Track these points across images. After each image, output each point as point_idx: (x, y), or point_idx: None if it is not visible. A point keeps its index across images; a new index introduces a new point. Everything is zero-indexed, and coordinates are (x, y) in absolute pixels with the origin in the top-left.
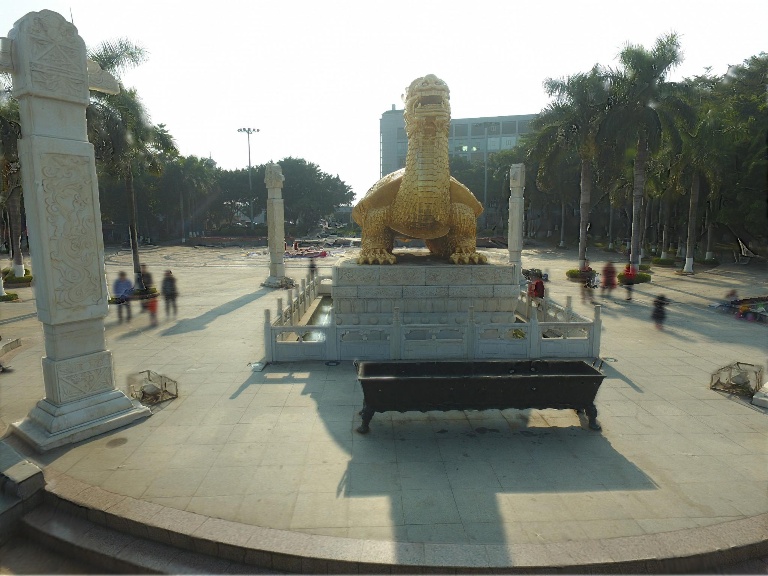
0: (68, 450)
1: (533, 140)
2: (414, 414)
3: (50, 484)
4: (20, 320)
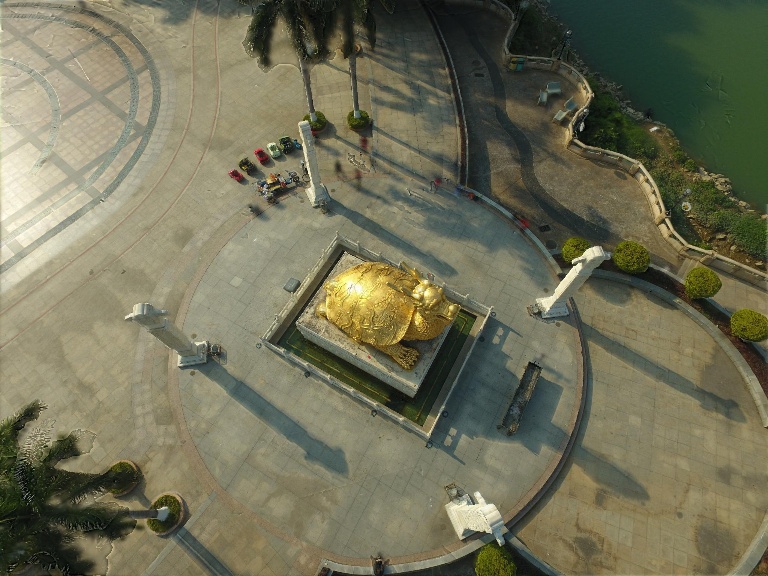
0: None
1: (250, 33)
2: None
3: None
4: (231, 573)
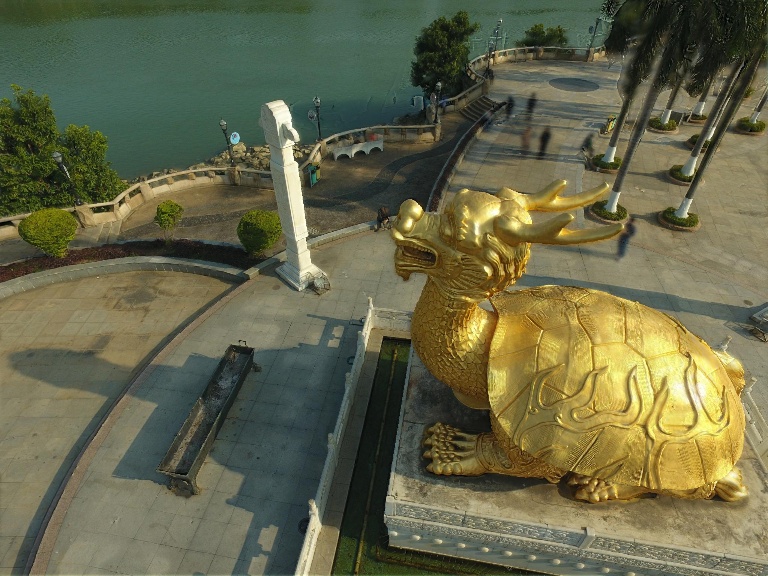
0: (276, 277)
1: None
2: (245, 392)
3: (250, 280)
4: None
